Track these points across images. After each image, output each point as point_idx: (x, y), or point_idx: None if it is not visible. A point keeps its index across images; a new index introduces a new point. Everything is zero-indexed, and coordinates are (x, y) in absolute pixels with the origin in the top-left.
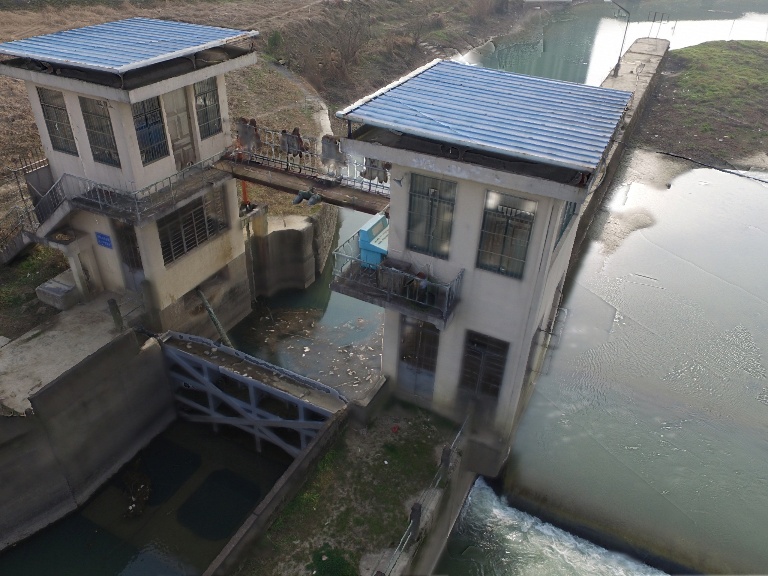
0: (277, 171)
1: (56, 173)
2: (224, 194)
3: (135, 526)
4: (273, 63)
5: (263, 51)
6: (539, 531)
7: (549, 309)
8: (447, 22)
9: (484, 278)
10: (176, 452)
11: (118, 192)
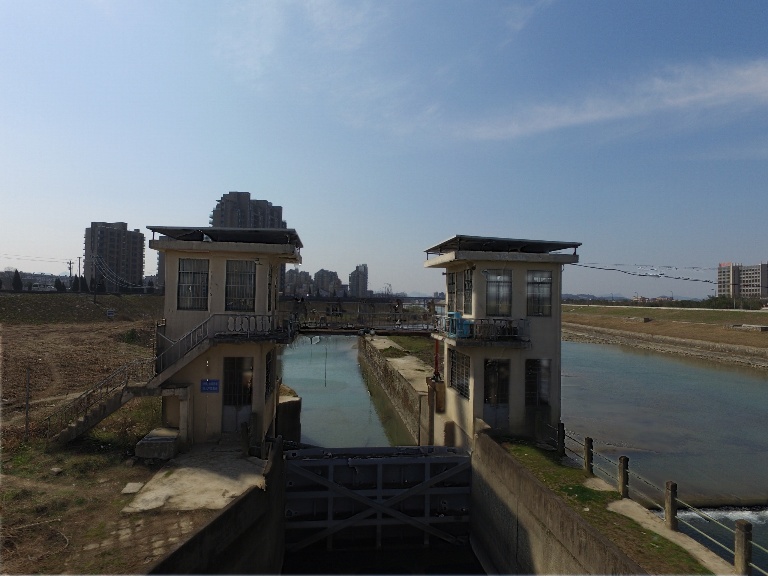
0: (326, 328)
1: (171, 331)
2: (273, 358)
3: None
4: None
5: None
6: None
7: None
8: None
9: (532, 321)
10: None
11: (244, 333)
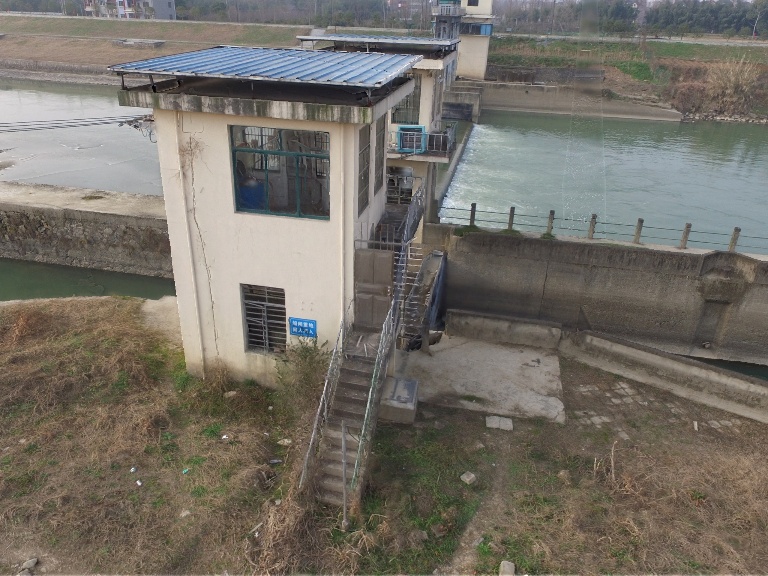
0: None
1: None
2: None
3: None
4: None
5: None
6: None
7: None
8: None
9: None
10: None
11: None
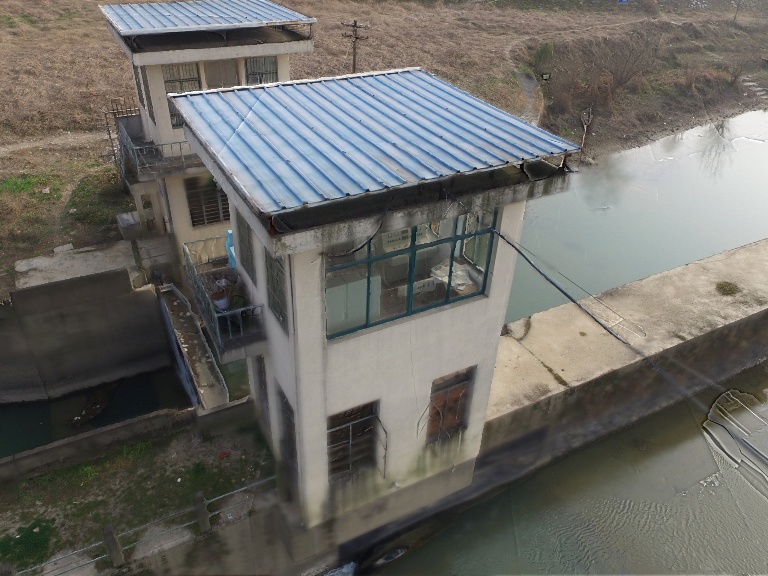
0: None
1: None
2: None
3: (68, 434)
4: (525, 75)
5: (526, 62)
6: None
7: (414, 401)
8: None
9: (273, 322)
10: (151, 393)
11: None
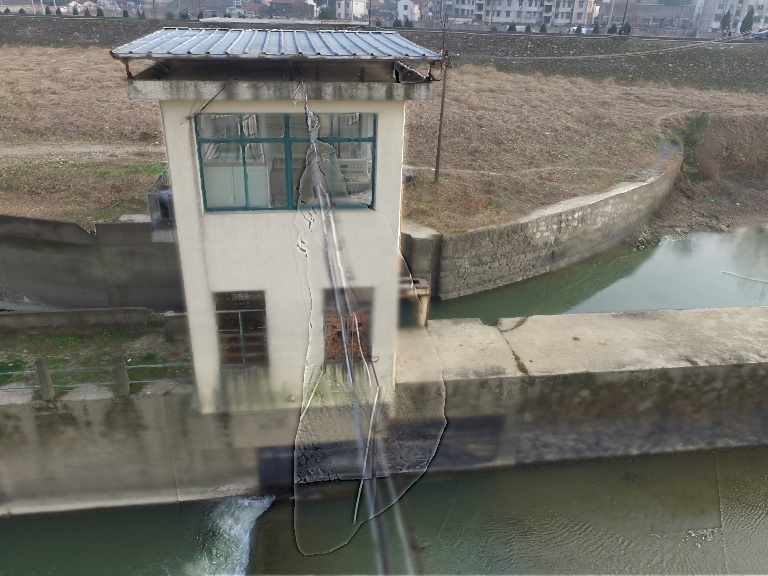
0: None
1: None
2: None
3: None
4: (671, 141)
5: (678, 130)
6: (234, 571)
7: (303, 306)
8: None
9: None
10: None
11: None
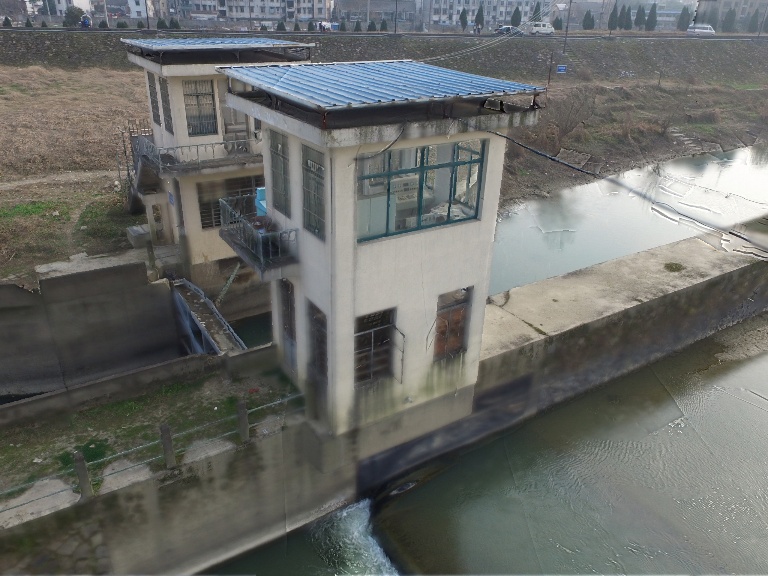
0: None
1: (155, 141)
2: None
3: None
4: None
5: None
6: (381, 572)
7: (424, 314)
8: (725, 118)
9: (308, 239)
10: None
11: (174, 156)
